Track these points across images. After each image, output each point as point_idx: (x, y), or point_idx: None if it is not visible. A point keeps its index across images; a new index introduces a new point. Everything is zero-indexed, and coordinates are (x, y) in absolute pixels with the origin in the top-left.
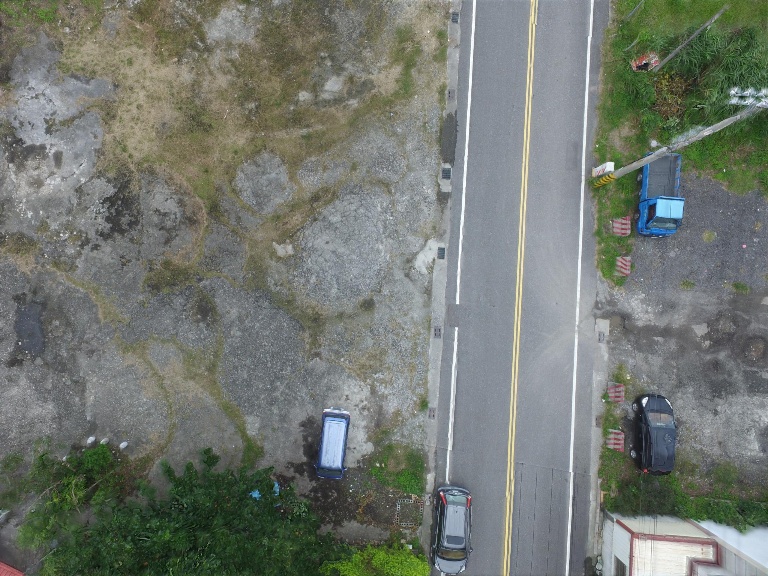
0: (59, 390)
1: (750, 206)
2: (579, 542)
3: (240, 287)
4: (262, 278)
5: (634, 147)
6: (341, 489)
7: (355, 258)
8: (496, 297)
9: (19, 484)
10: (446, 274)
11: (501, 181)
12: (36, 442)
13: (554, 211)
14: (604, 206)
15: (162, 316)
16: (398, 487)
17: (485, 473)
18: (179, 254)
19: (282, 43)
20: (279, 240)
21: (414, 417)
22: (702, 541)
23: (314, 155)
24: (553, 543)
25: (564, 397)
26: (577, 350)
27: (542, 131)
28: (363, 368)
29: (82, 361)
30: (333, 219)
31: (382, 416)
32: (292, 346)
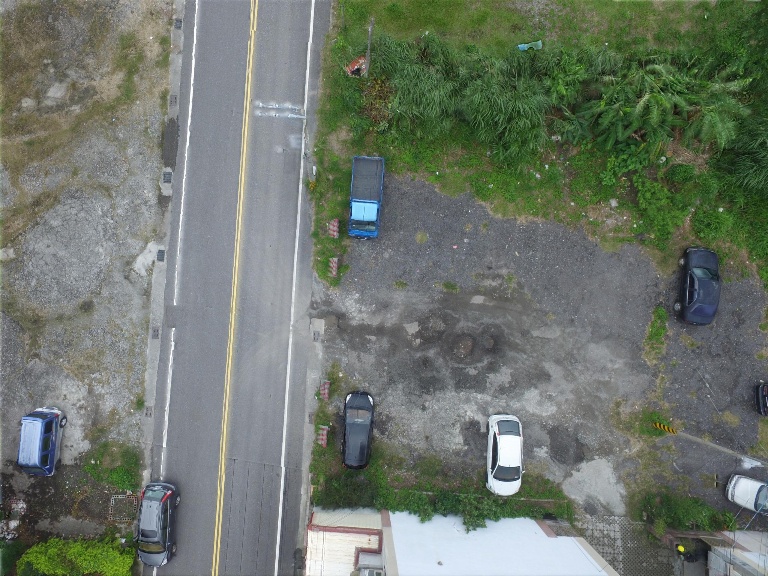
0: None
1: (462, 208)
2: (289, 534)
3: None
4: None
5: (350, 151)
6: (58, 486)
7: (75, 261)
8: (213, 298)
9: None
10: (165, 276)
11: (219, 185)
12: None
13: (271, 214)
14: (320, 209)
15: None
16: (112, 483)
17: (198, 469)
18: None
19: (5, 50)
20: (0, 244)
21: (131, 415)
22: (369, 532)
23: (36, 160)
24: (263, 535)
25: (278, 395)
26: (291, 349)
27: (260, 135)
28: (81, 368)
29: None
30: (54, 223)
31: (99, 415)
32: (12, 347)
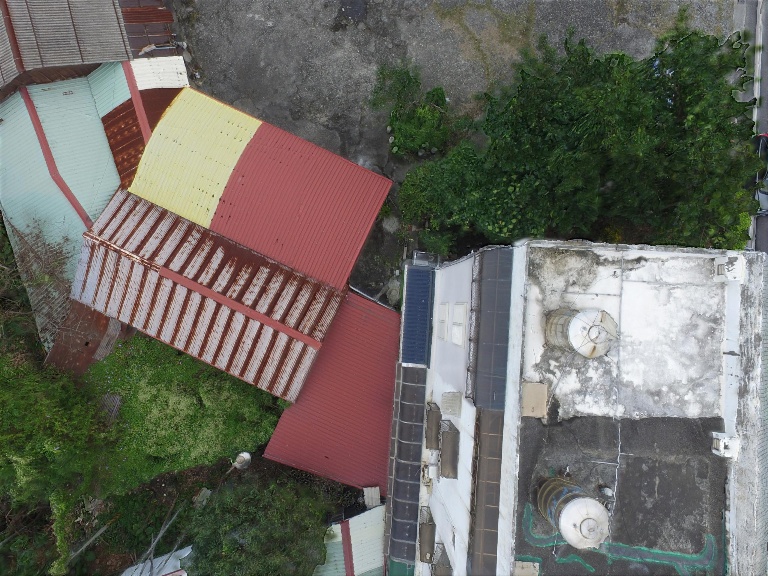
0: (382, 53)
1: None
2: None
3: None
4: None
5: None
6: None
7: None
8: None
9: (348, 139)
10: None
11: None
12: (362, 101)
13: None
14: None
15: None
16: None
17: None
18: None
19: None
20: None
21: None
22: None
23: None
24: None
25: None
26: None
27: None
28: (670, 31)
29: (402, 26)
30: None
31: None
32: (601, 12)
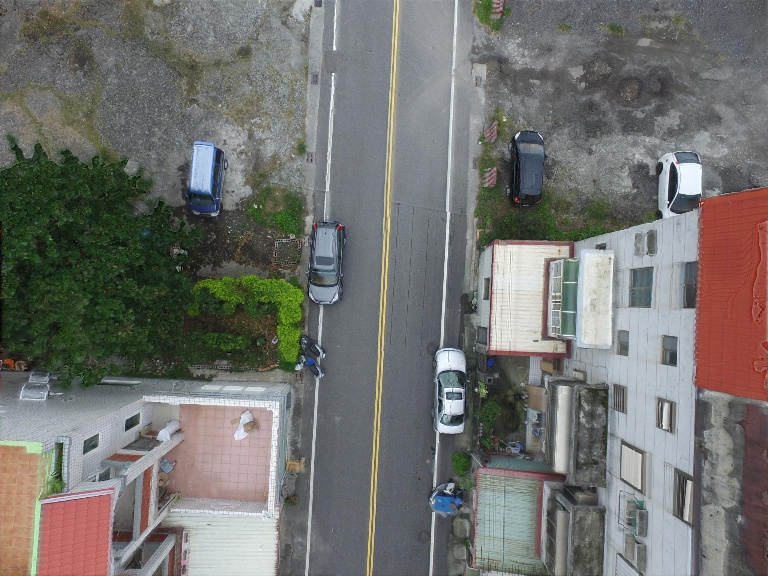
0: None
1: None
2: (455, 279)
3: (117, 36)
4: (139, 27)
5: None
6: (220, 231)
7: (232, 6)
8: (373, 42)
9: None
10: (323, 21)
11: None
12: None
13: None
14: None
15: (39, 64)
16: (276, 227)
17: (362, 213)
18: (55, 4)
19: None
20: None
21: (292, 161)
22: (559, 243)
23: None
24: (429, 280)
25: (441, 140)
26: (453, 93)
27: None
28: (240, 113)
29: None
30: None
31: (260, 160)
32: (169, 93)
